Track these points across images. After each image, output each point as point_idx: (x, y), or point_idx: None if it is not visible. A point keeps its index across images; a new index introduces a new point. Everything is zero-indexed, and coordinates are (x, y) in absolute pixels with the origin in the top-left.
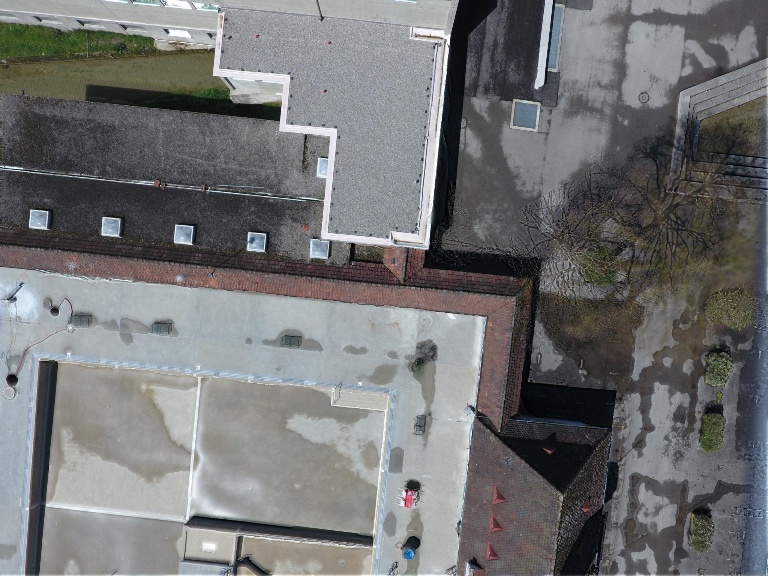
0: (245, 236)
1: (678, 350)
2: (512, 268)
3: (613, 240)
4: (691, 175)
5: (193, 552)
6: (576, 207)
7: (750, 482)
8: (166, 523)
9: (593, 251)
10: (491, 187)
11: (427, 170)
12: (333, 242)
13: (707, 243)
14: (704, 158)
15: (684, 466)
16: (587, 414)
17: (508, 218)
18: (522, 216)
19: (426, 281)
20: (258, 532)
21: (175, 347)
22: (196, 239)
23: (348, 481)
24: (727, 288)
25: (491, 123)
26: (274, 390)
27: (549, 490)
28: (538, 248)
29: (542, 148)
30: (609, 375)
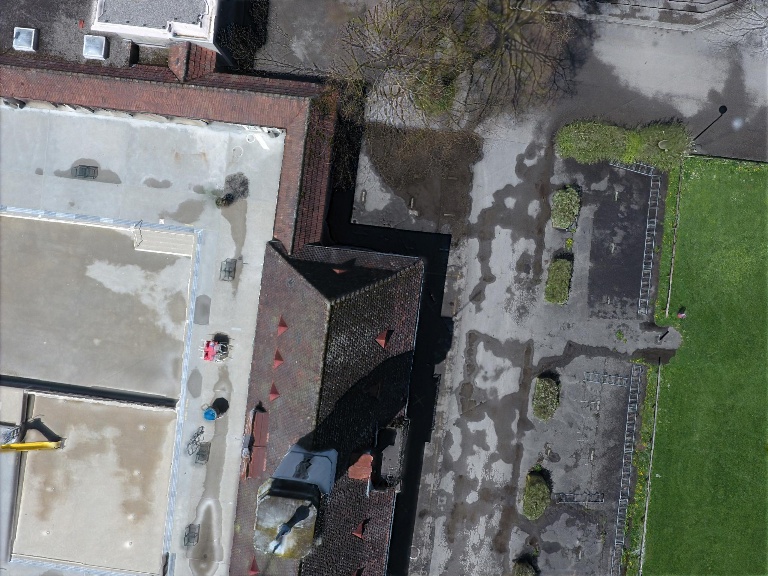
0: (12, 32)
1: (522, 189)
2: None
3: (448, 62)
4: None
5: None
6: (406, 23)
7: (605, 344)
8: None
9: (425, 73)
10: None
11: None
12: (107, 37)
13: (556, 67)
14: None
15: (528, 323)
16: None
17: (329, 35)
18: (345, 33)
19: (211, 82)
20: (50, 390)
21: None
22: None
23: (153, 336)
24: (579, 120)
25: None
26: (72, 232)
27: (319, 301)
28: (362, 69)
29: None
30: (443, 217)
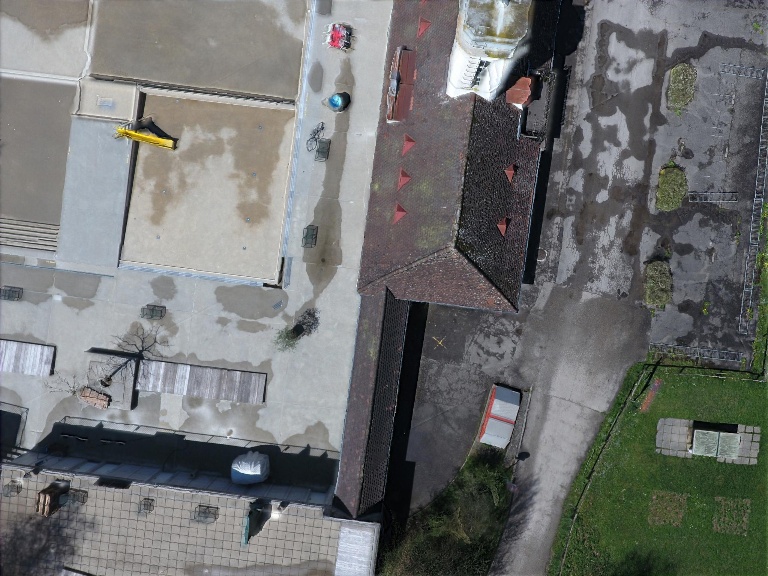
0: None
1: None
2: None
3: None
4: None
5: (87, 107)
6: None
7: (741, 34)
8: (59, 83)
9: None
10: None
11: None
12: None
13: None
14: None
15: (663, 12)
16: None
17: None
18: None
19: None
20: None
21: None
22: None
23: (270, 34)
24: None
25: None
26: None
27: None
28: None
29: None
30: None
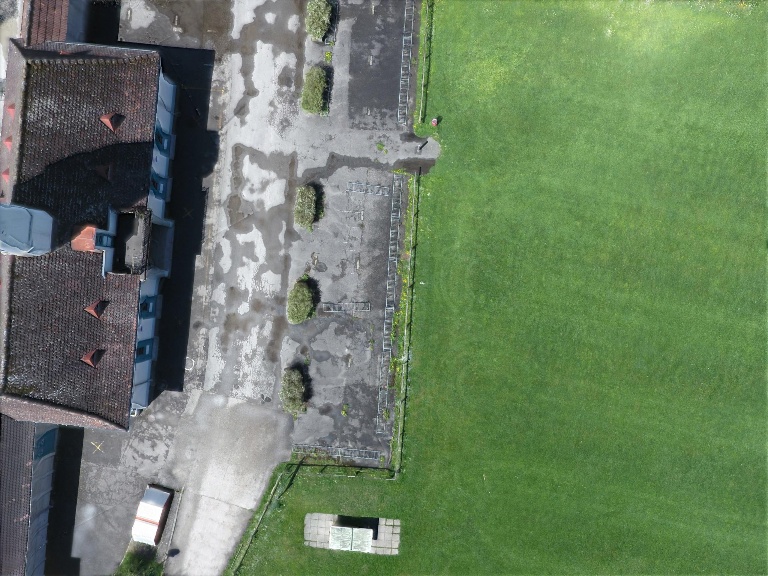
0: None
1: (282, 4)
2: None
3: None
4: None
5: None
6: None
7: (366, 154)
8: None
9: None
10: None
11: None
12: None
13: None
14: None
15: (292, 136)
16: (183, 77)
17: None
18: None
19: None
20: None
21: None
22: None
23: None
24: None
25: None
26: None
27: (23, 65)
28: None
29: None
30: (206, 33)
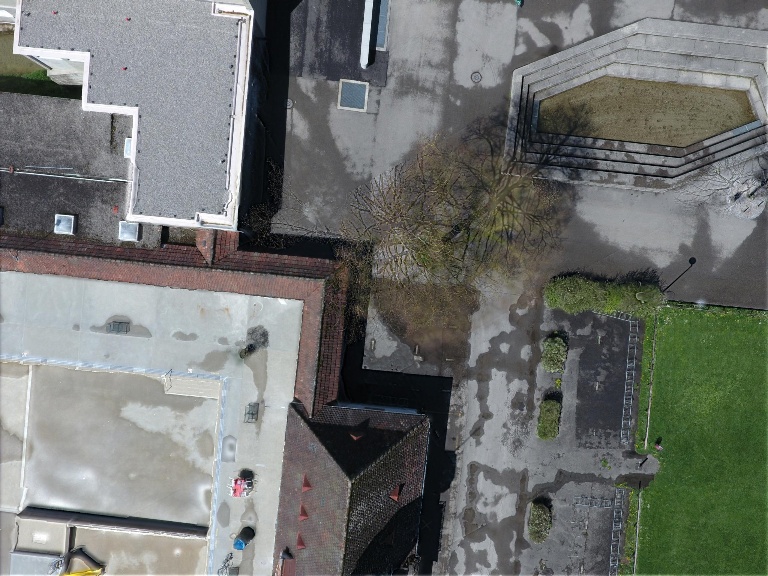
0: (53, 218)
1: (515, 336)
2: (334, 251)
3: (447, 223)
4: (526, 156)
5: (24, 543)
6: (408, 189)
7: (591, 471)
8: None
9: (426, 234)
10: (320, 169)
11: (234, 150)
12: (141, 224)
13: (544, 226)
14: (544, 139)
15: (523, 454)
16: (423, 401)
17: (339, 201)
18: (353, 199)
19: (236, 264)
20: (90, 523)
21: (1, 334)
22: (4, 222)
23: (183, 470)
24: (565, 272)
25: (318, 103)
26: (107, 378)
27: (341, 476)
28: (370, 231)
29: (371, 129)
30: (445, 361)
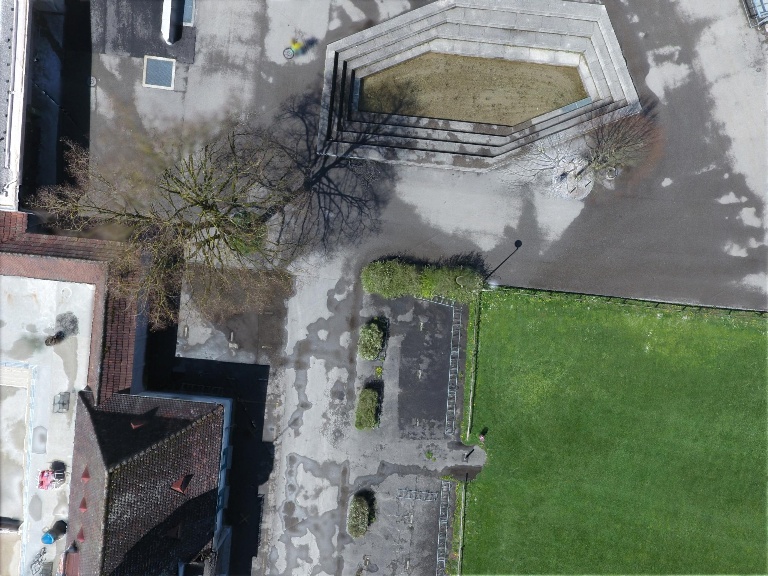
0: None
1: (334, 322)
2: (133, 234)
3: (261, 205)
4: (343, 136)
5: None
6: (219, 170)
7: (415, 462)
8: None
9: (238, 217)
10: (127, 149)
11: (14, 127)
12: None
13: (362, 208)
14: (365, 118)
15: (344, 445)
16: (239, 390)
17: (148, 182)
18: (162, 180)
19: (19, 246)
20: None
21: None
22: None
23: None
24: (386, 256)
25: (123, 81)
26: None
27: (103, 466)
28: (180, 214)
29: (179, 108)
30: (261, 349)
